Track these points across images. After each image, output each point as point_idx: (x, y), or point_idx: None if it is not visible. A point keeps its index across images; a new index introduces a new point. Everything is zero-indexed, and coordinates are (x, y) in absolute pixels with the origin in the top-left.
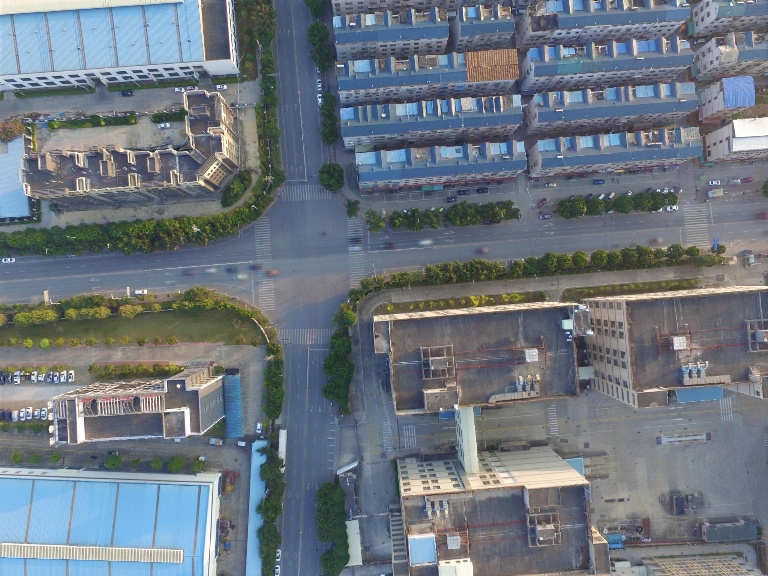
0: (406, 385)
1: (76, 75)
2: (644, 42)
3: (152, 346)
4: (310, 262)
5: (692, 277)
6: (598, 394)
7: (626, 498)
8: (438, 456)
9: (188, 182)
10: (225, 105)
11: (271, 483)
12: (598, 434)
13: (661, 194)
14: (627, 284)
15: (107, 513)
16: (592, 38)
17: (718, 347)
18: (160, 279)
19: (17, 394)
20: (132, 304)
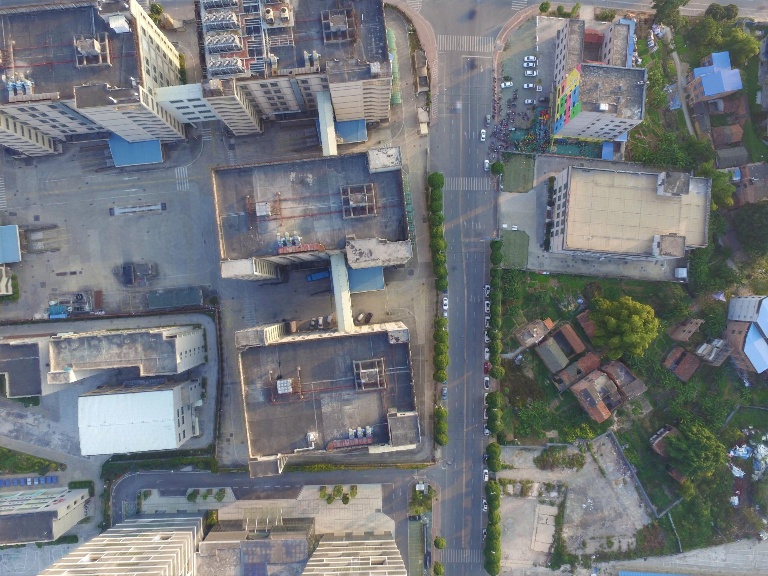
0: None
1: None
2: None
3: None
4: None
5: None
6: (48, 166)
7: (78, 271)
8: None
9: None
10: None
11: None
12: (49, 207)
13: None
14: None
15: None
16: None
17: (47, 64)
18: None
19: None
20: None
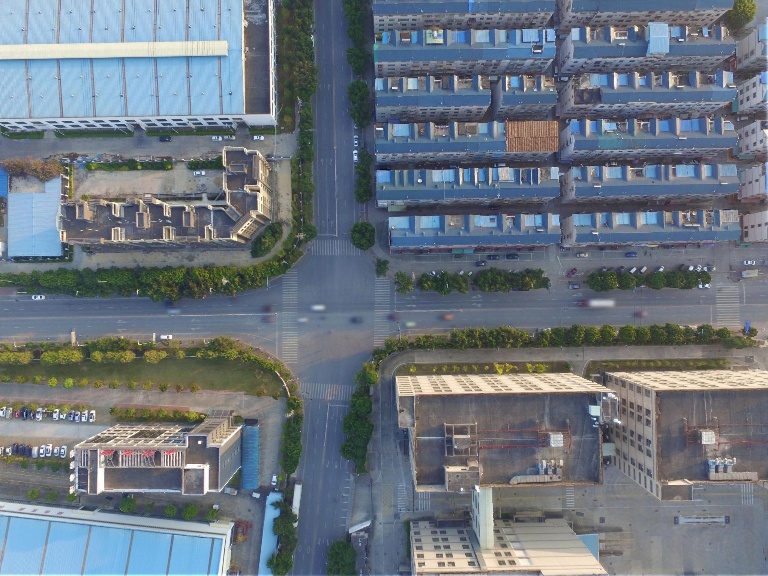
0: (427, 460)
1: (117, 120)
2: (687, 121)
3: (174, 391)
4: (335, 317)
5: (720, 357)
6: (617, 469)
7: None
8: (452, 523)
9: (222, 238)
10: (262, 161)
11: (283, 539)
12: (615, 509)
13: (695, 273)
14: (654, 360)
15: (120, 560)
16: (634, 111)
17: (747, 443)
18: (186, 325)
19: (38, 430)
20: (157, 349)
